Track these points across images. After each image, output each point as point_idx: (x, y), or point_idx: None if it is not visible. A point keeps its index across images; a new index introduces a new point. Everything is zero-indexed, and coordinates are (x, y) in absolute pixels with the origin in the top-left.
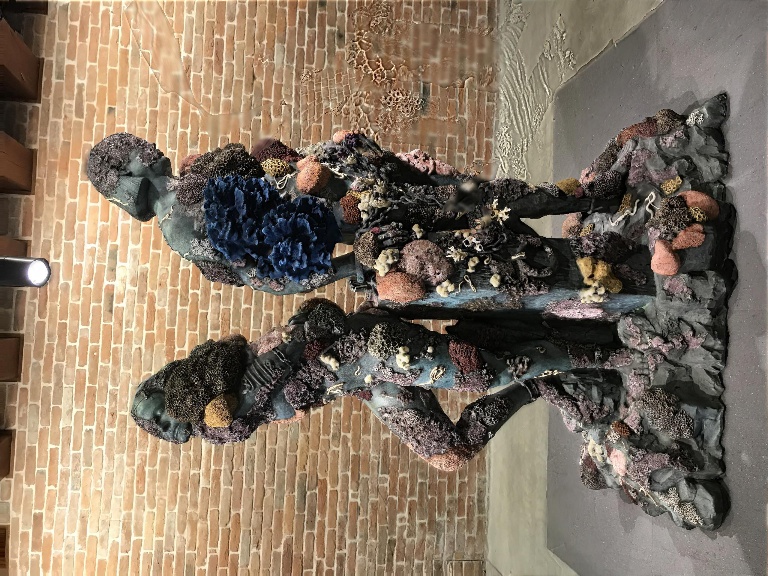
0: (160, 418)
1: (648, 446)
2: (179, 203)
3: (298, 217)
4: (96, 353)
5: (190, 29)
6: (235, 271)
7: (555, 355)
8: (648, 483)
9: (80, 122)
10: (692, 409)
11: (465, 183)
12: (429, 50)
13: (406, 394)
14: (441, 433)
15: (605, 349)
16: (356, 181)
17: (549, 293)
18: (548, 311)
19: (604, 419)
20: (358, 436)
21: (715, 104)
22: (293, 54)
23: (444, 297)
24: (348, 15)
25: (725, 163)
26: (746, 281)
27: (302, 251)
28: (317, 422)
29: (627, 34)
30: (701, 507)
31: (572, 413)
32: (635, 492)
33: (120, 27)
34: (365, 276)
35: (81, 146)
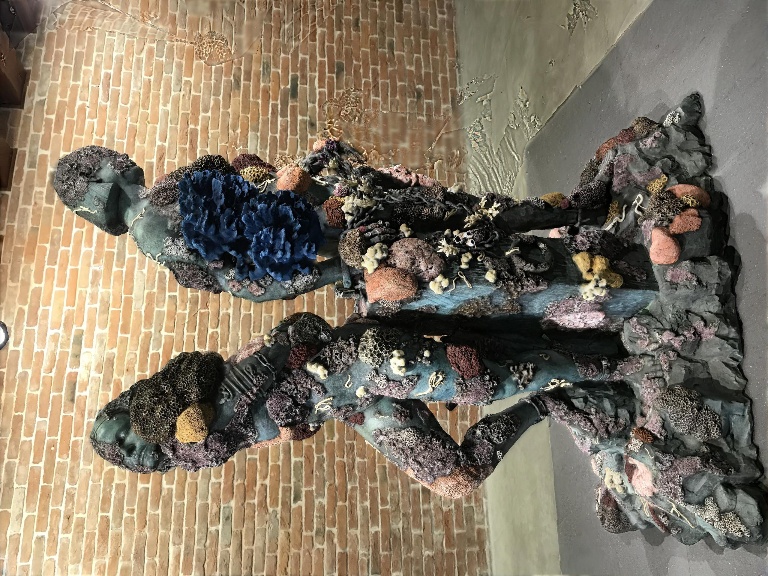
0: (124, 441)
1: (675, 451)
2: (152, 206)
3: (280, 206)
4: (54, 448)
5: (165, 120)
6: (212, 273)
7: (560, 362)
8: (681, 493)
9: (50, 208)
10: (716, 404)
11: (461, 103)
12: (398, 136)
13: (402, 412)
14: (445, 452)
15: (612, 359)
16: (339, 184)
17: (548, 290)
18: (548, 318)
19: (621, 433)
20: (344, 531)
21: (689, 103)
22: (266, 141)
23: (438, 297)
24: (319, 106)
25: (708, 155)
26: (751, 262)
27: (285, 238)
28: (298, 516)
29: (591, 73)
30: (745, 515)
31: (585, 428)
32: (666, 516)
33: (96, 120)
34: (352, 280)
35: (50, 231)
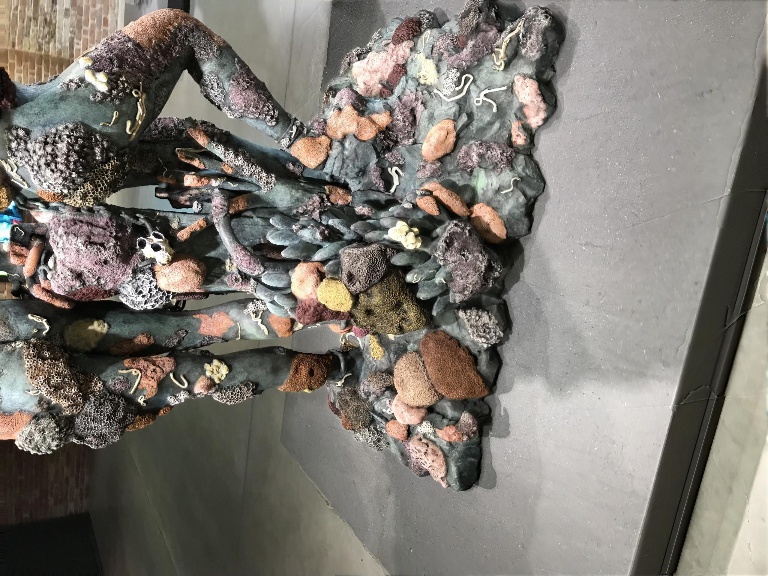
0: None
1: None
2: None
3: None
4: None
5: None
6: None
7: None
8: None
9: None
10: None
11: None
12: None
13: None
14: None
15: None
16: None
17: None
18: None
19: None
20: None
21: None
22: None
23: None
24: None
25: None
26: None
27: None
28: None
29: None
30: None
31: None
32: None
33: None
34: None
35: None
